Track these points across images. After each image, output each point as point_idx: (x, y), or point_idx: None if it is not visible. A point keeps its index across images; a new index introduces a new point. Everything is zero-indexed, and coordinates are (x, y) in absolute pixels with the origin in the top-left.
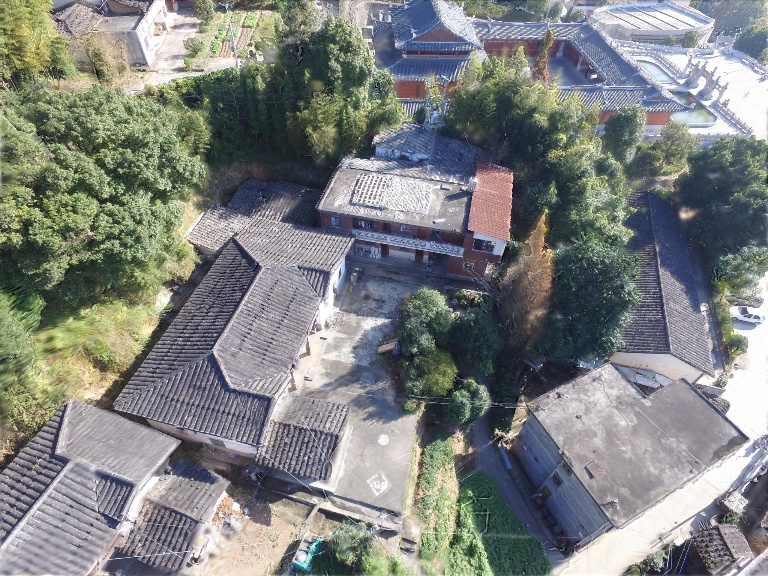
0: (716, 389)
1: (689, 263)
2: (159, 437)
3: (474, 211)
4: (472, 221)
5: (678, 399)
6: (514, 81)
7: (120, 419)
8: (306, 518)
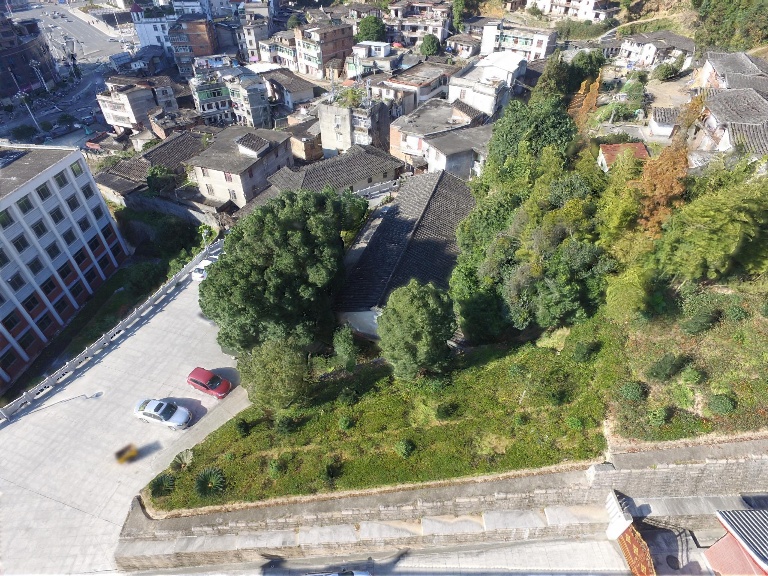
0: (396, 193)
1: (371, 242)
2: (738, 86)
3: (644, 155)
4: (642, 148)
5: (454, 149)
6: (701, 170)
7: (765, 90)
8: (646, 122)
